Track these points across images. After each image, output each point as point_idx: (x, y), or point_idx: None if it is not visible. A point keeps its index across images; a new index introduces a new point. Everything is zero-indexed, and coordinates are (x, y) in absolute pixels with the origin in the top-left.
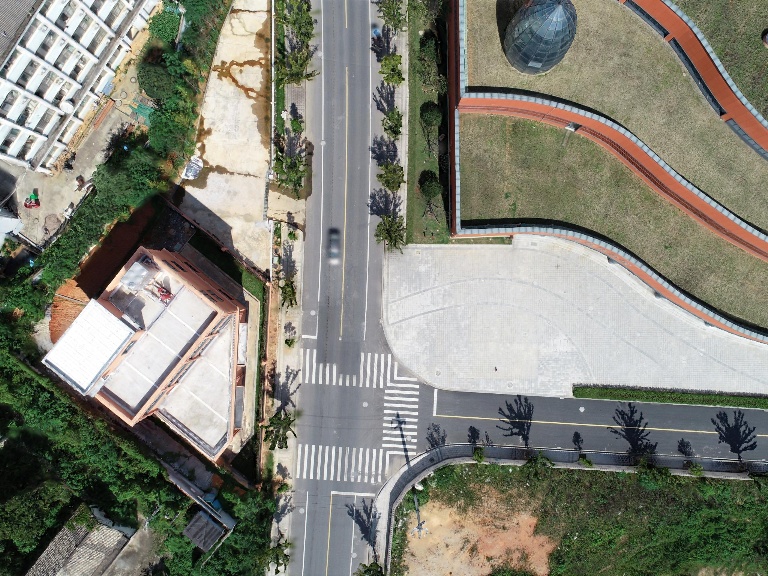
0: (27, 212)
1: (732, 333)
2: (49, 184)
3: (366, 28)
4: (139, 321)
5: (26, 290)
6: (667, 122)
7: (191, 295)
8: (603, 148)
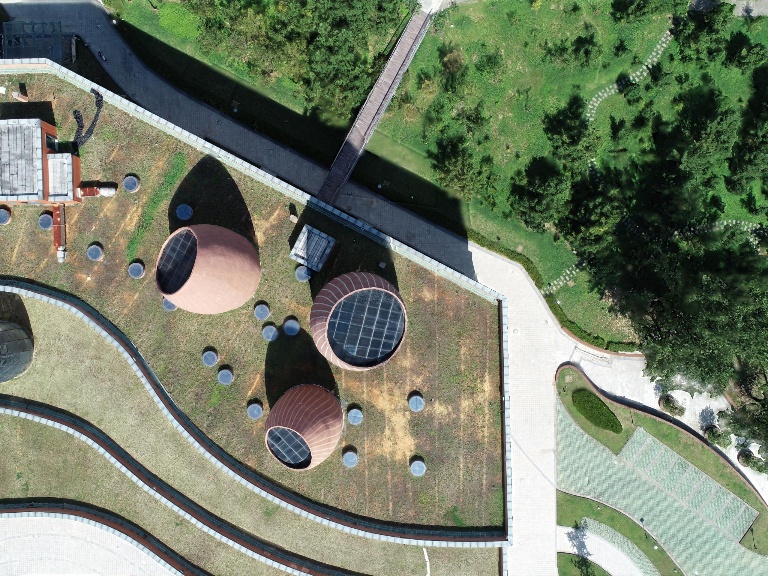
0: None
1: None
2: None
3: None
4: None
5: None
6: (139, 423)
7: None
8: None
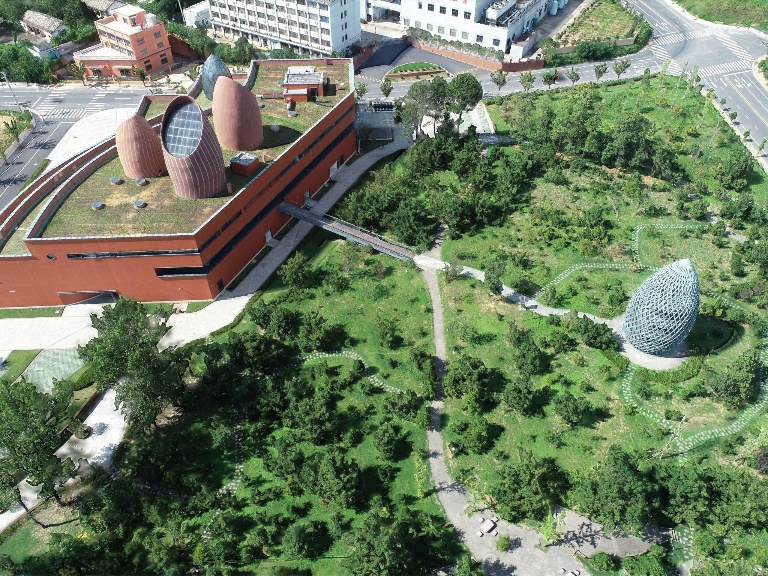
0: None
1: None
2: (210, 34)
3: None
4: None
5: (163, 19)
6: None
7: None
8: None
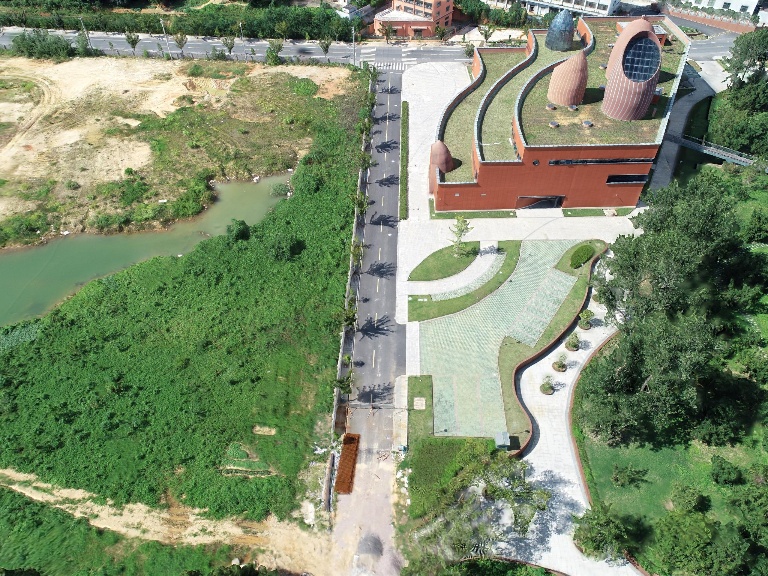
0: None
1: None
2: None
3: None
4: None
5: None
6: None
7: None
8: None
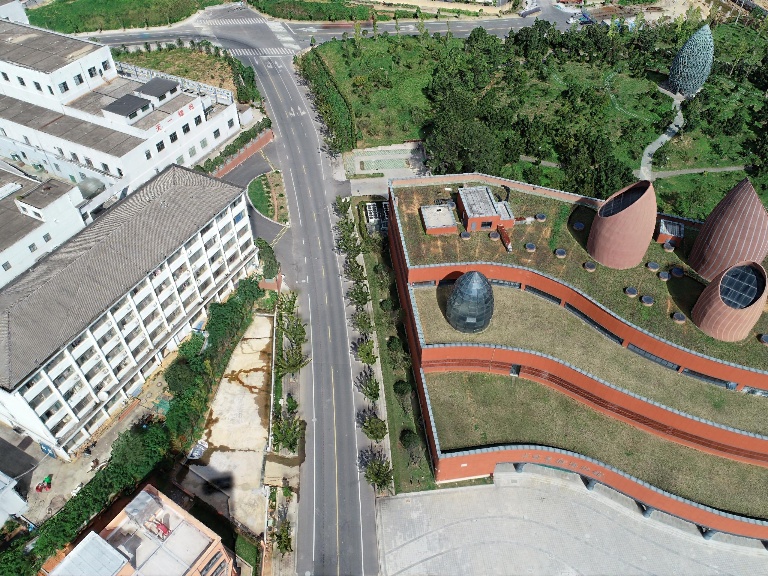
0: (36, 496)
1: (729, 533)
2: (65, 469)
3: (345, 341)
4: (131, 562)
5: (16, 556)
6: (583, 353)
7: (189, 529)
8: (545, 386)
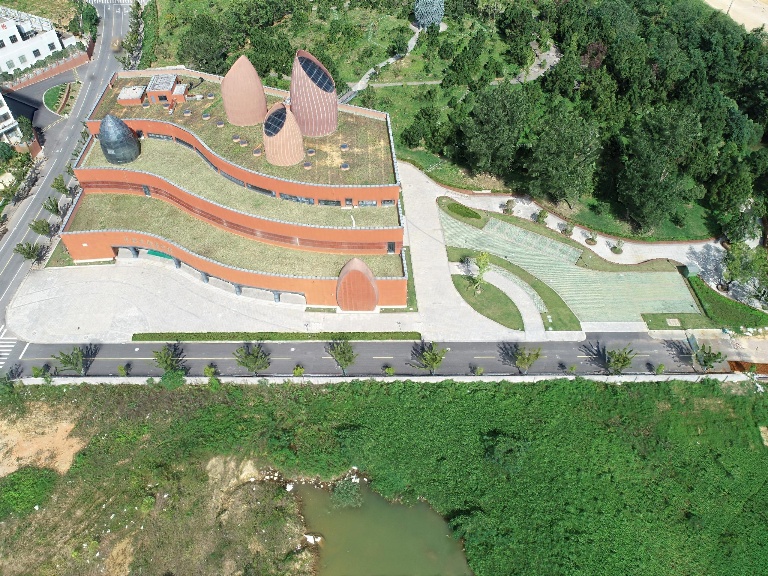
0: None
1: (241, 285)
2: None
3: None
4: None
5: None
6: None
7: None
8: (167, 202)
